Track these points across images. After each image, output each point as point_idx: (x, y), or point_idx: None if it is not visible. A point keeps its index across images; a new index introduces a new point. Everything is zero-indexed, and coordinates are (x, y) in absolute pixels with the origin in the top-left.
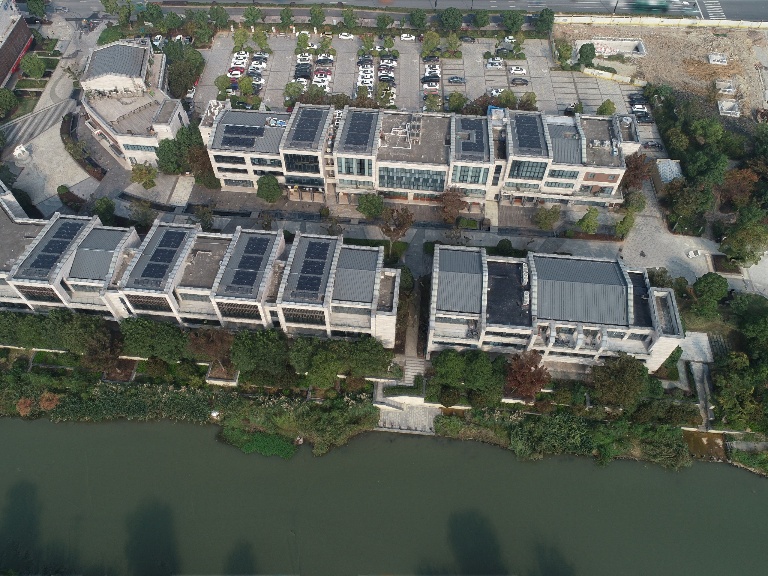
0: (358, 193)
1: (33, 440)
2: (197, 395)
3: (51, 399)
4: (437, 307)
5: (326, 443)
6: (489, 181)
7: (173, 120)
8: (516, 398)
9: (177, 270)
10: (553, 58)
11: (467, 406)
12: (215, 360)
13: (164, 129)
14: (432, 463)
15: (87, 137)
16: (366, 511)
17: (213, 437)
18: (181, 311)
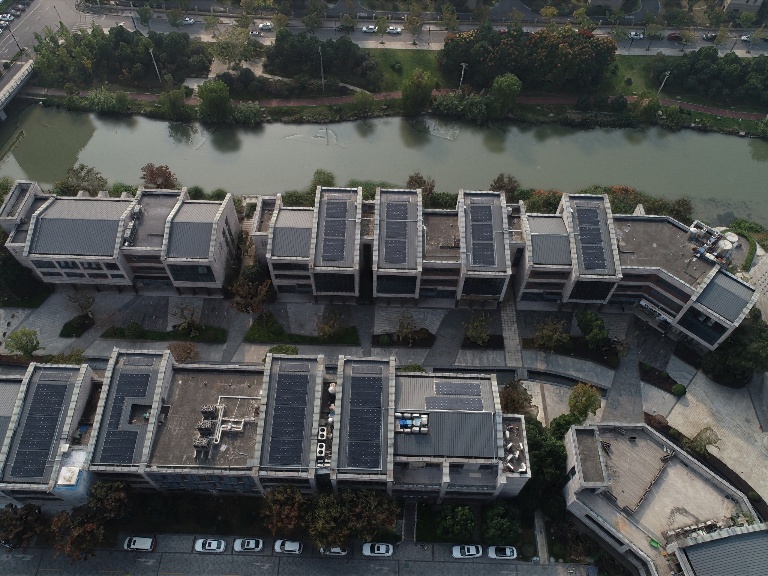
0: None
1: (542, 185)
2: None
3: None
4: None
5: None
6: None
7: None
8: None
9: (461, 213)
10: None
11: None
12: None
13: None
14: (247, 183)
15: None
16: (296, 159)
17: None
18: None
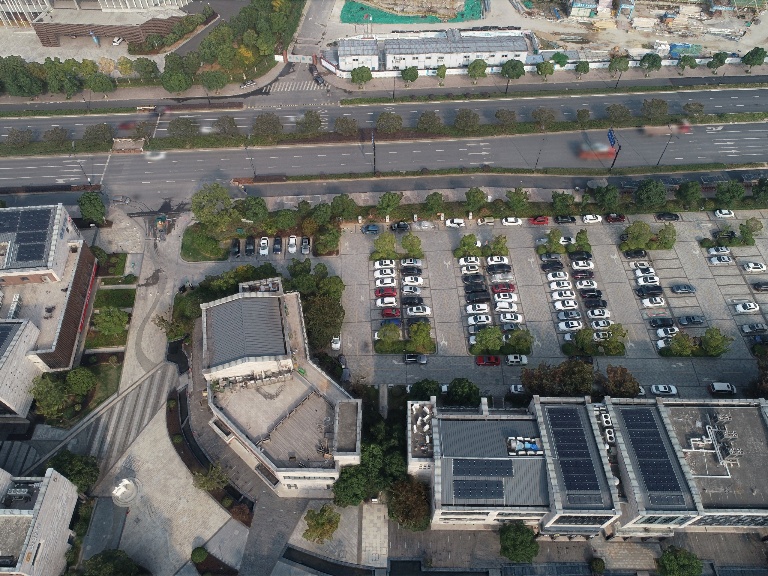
0: (647, 536)
1: None
2: None
3: None
4: None
5: None
6: None
7: None
8: None
9: None
10: None
11: None
12: None
13: (349, 457)
14: None
15: (208, 436)
16: None
17: None
18: None
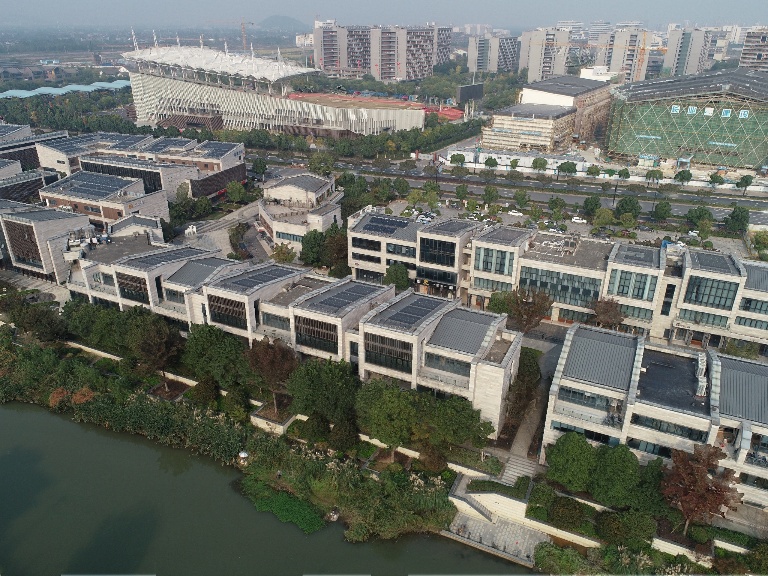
0: None
1: (44, 433)
2: (233, 429)
3: (86, 395)
4: (564, 372)
5: (367, 527)
6: (657, 296)
7: (327, 216)
8: (679, 543)
9: (269, 285)
10: (748, 251)
11: (593, 539)
12: (271, 402)
13: (316, 220)
14: None
15: (251, 237)
16: None
17: (228, 482)
18: (256, 332)
